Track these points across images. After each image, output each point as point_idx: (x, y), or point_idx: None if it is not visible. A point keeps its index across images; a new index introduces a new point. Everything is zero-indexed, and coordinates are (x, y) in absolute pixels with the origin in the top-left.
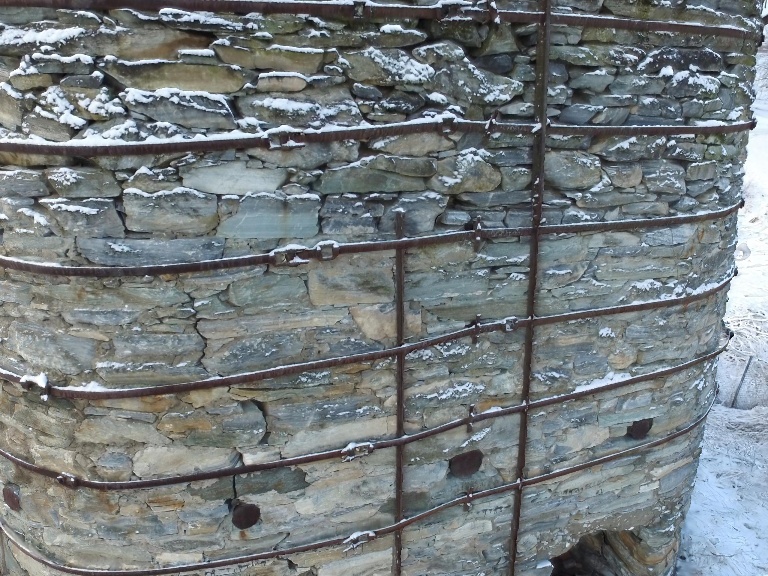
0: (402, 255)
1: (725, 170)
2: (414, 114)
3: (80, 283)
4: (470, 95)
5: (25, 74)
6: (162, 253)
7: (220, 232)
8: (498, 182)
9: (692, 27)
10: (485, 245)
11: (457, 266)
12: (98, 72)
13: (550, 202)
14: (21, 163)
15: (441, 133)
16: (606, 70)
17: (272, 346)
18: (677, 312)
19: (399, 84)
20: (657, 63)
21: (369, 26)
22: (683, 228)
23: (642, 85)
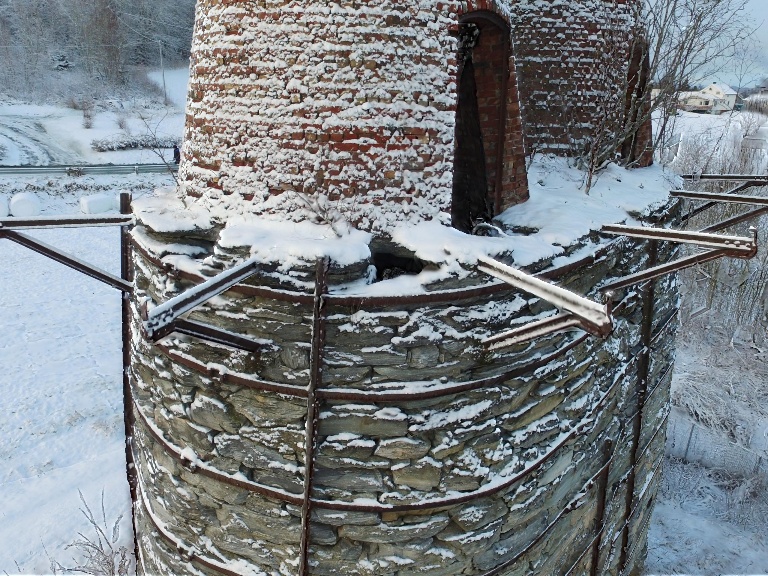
0: None
1: None
2: None
3: None
4: None
5: (449, 447)
6: (522, 541)
7: (546, 507)
8: None
9: None
10: None
11: None
12: (499, 429)
13: None
14: (426, 513)
15: None
16: None
17: (558, 569)
18: None
19: None
20: None
21: None
22: None
23: None
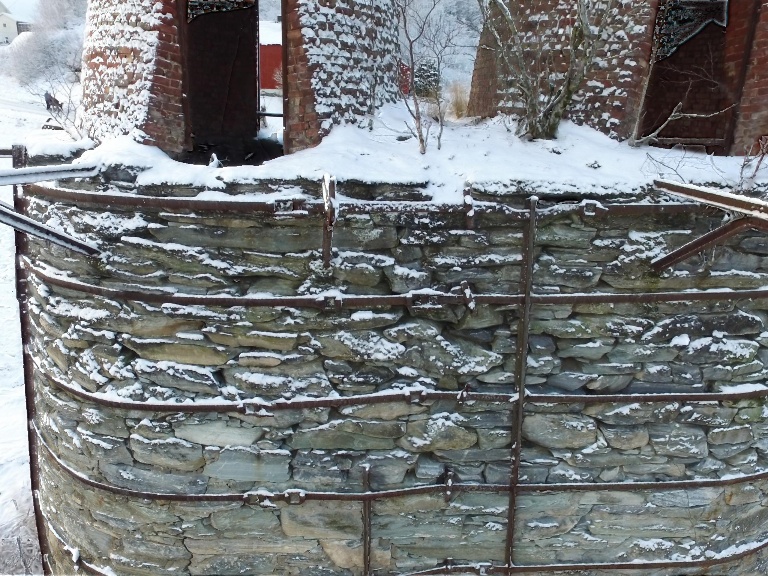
0: (366, 505)
1: (766, 431)
2: (384, 384)
3: (101, 493)
4: (442, 368)
5: (71, 338)
6: (158, 484)
7: (205, 472)
8: (474, 441)
9: (717, 294)
10: (461, 494)
11: (427, 513)
12: (117, 345)
13: (533, 461)
14: (69, 395)
15: (409, 403)
16: (601, 341)
17: (247, 565)
18: (695, 572)
19: (368, 361)
20: (668, 332)
21: (341, 312)
22: (703, 490)
23: (647, 354)
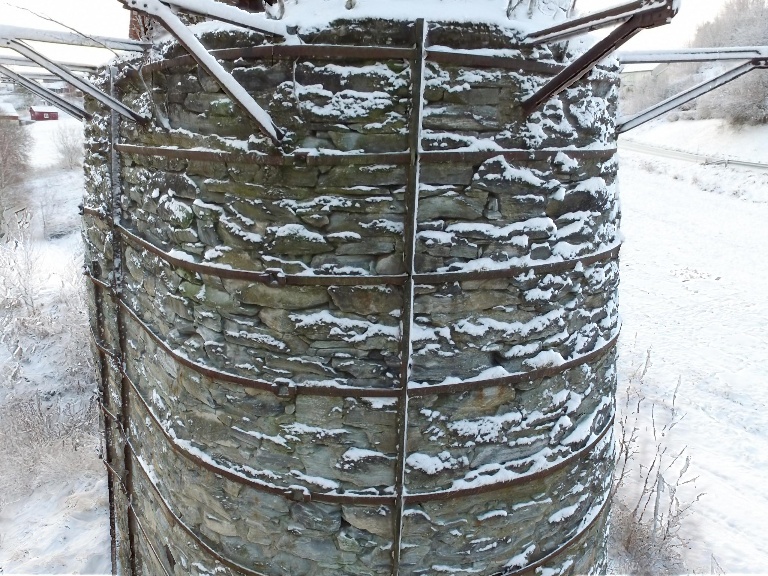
0: (95, 286)
1: None
2: None
3: None
4: None
5: None
6: None
7: None
8: None
9: None
10: None
11: None
12: None
13: None
14: None
15: None
16: None
17: None
18: None
19: None
20: None
21: None
22: None
23: None
